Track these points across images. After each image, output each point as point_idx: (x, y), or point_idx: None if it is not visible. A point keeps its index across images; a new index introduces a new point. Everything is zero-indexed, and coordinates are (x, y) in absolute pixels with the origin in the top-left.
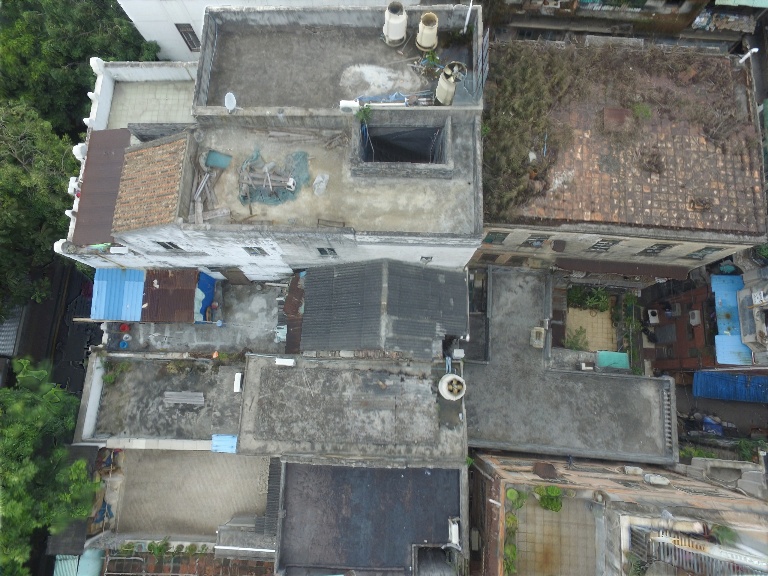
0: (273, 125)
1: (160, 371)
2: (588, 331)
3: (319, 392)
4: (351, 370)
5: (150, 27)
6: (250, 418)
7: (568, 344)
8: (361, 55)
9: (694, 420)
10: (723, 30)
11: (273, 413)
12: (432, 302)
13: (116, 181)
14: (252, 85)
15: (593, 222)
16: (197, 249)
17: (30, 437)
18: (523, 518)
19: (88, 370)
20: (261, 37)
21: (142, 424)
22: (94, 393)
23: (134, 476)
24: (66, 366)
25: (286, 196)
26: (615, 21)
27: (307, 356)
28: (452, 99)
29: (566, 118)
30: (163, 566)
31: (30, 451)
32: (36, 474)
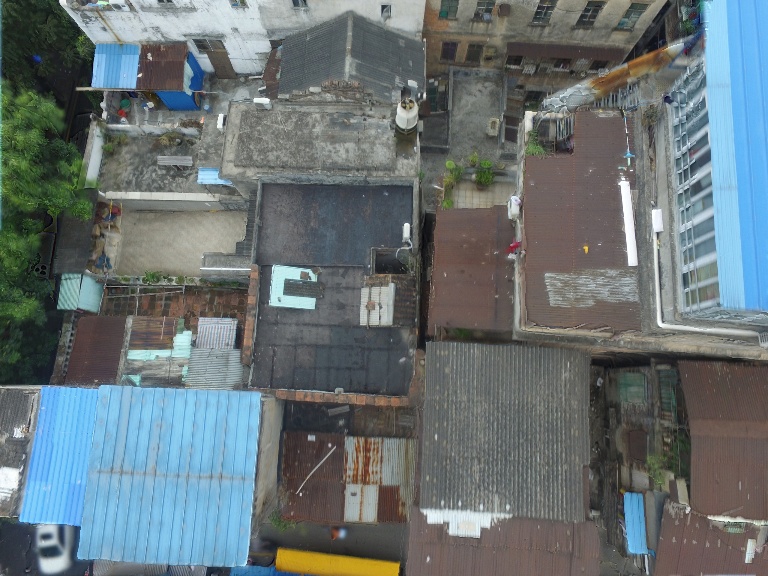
0: None
1: (153, 145)
2: None
3: (292, 129)
4: (320, 112)
5: None
6: (231, 151)
7: None
8: None
9: None
10: None
11: (251, 145)
12: (392, 59)
13: None
14: None
15: None
16: (185, 1)
17: (40, 141)
18: (462, 199)
19: (89, 135)
20: None
21: (137, 188)
22: (95, 158)
23: (130, 236)
24: None
25: None
26: None
27: (281, 98)
28: None
29: None
30: (156, 303)
31: (39, 156)
32: (45, 174)
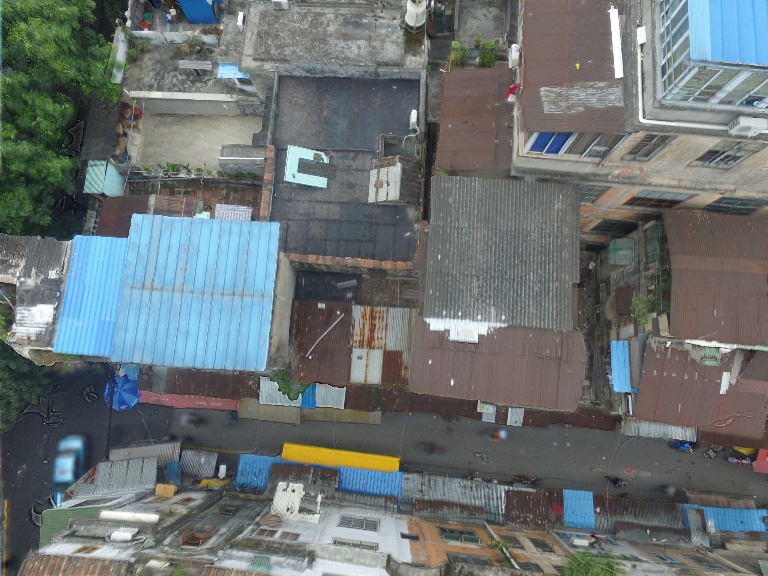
0: None
1: (175, 52)
2: None
3: (307, 27)
4: (334, 13)
5: None
6: (250, 46)
7: None
8: None
9: None
10: None
11: (269, 40)
12: None
13: None
14: None
15: None
16: None
17: (73, 24)
18: None
19: (115, 39)
20: None
21: None
22: (119, 62)
23: (151, 137)
24: None
25: None
26: None
27: None
28: None
29: None
30: None
31: (72, 40)
32: None
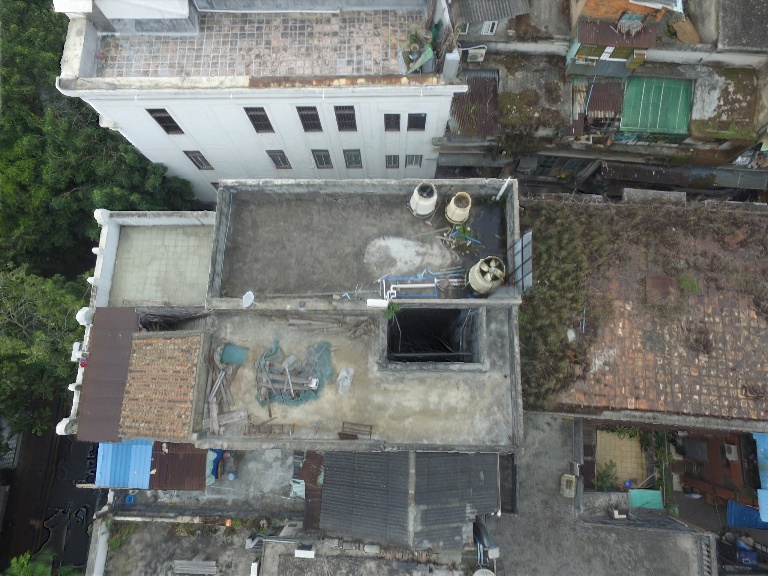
0: (293, 313)
1: (169, 532)
2: (616, 455)
3: None
4: (376, 559)
5: (157, 153)
6: None
7: (598, 483)
8: (386, 226)
9: (727, 544)
10: (766, 167)
11: None
12: (461, 480)
13: (123, 369)
14: (270, 263)
15: (637, 410)
16: None
17: None
18: None
19: (93, 538)
20: (279, 206)
21: None
22: (99, 561)
23: None
24: (68, 485)
25: (308, 395)
26: (650, 155)
27: (328, 545)
28: (488, 293)
29: (605, 287)
30: None
31: None
32: None
